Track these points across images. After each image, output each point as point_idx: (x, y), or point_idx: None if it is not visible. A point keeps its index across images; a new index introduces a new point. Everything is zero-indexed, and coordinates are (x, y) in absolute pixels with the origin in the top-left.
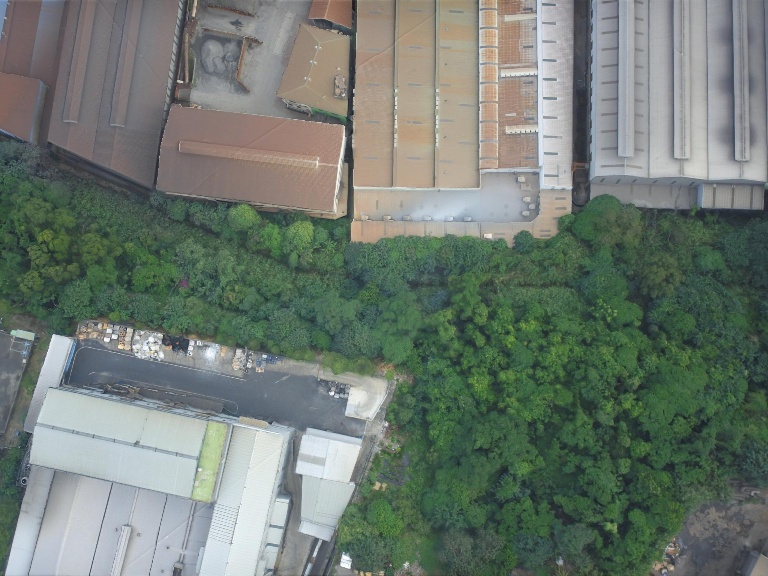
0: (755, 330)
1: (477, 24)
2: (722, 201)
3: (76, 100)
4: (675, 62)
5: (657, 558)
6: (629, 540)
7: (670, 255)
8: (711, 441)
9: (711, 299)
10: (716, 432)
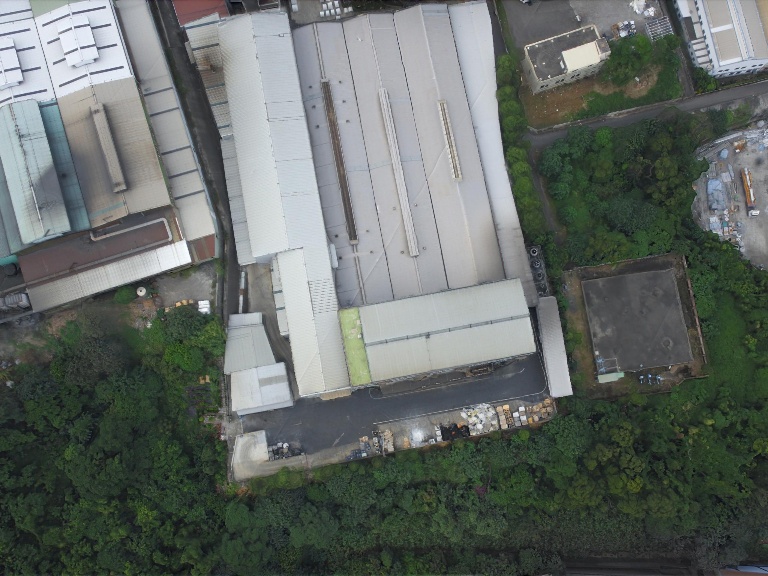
0: None
1: None
2: None
3: None
4: None
5: None
6: None
7: None
8: None
9: None
10: None
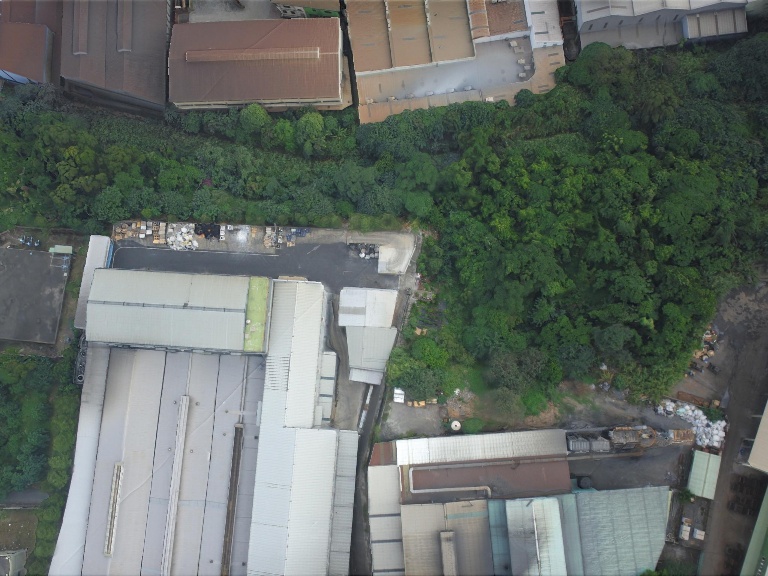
0: (757, 138)
1: None
2: (707, 29)
3: (83, 33)
4: None
5: (696, 347)
6: (667, 331)
7: (665, 84)
8: (730, 225)
9: (711, 113)
10: (734, 221)
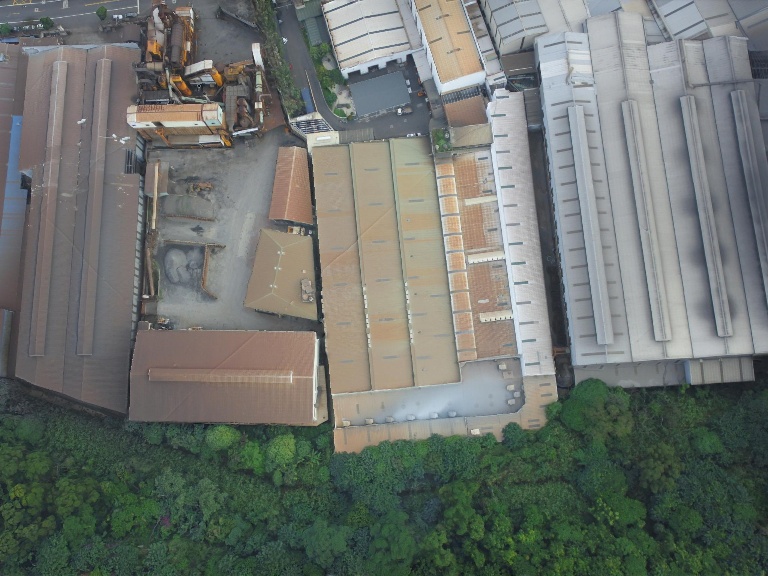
0: (766, 517)
1: (438, 211)
2: (711, 376)
3: (41, 333)
4: (642, 240)
5: None
6: None
7: (665, 441)
8: None
9: (715, 491)
10: None
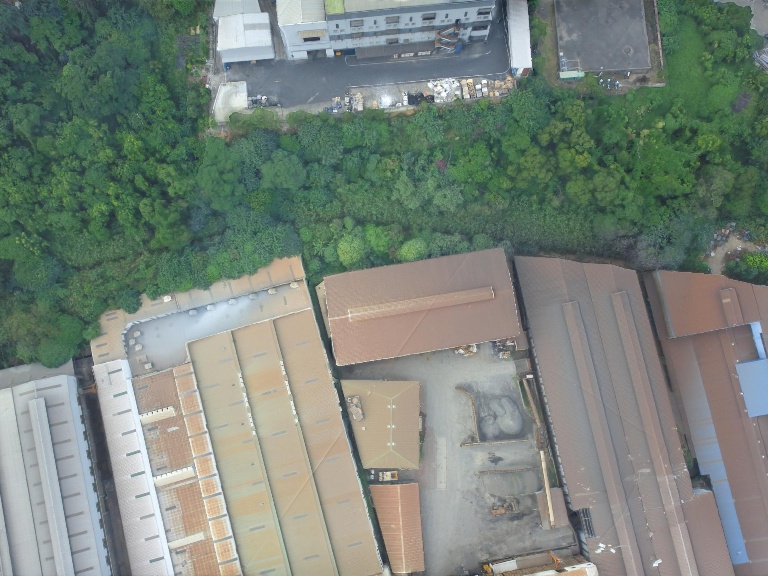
0: None
1: (232, 521)
2: None
3: (621, 316)
4: (2, 516)
5: None
6: None
7: None
8: None
9: None
10: None
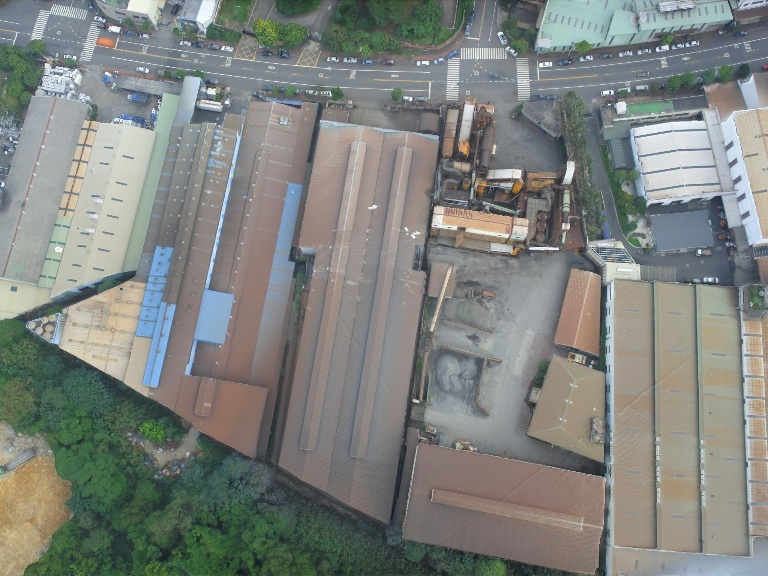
0: None
1: (740, 369)
2: None
3: (314, 427)
4: None
5: None
6: None
7: None
8: None
9: None
10: None
